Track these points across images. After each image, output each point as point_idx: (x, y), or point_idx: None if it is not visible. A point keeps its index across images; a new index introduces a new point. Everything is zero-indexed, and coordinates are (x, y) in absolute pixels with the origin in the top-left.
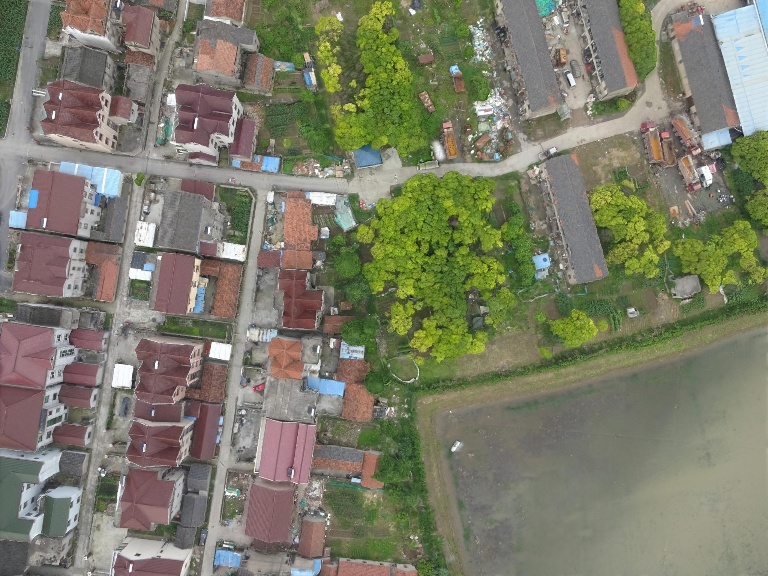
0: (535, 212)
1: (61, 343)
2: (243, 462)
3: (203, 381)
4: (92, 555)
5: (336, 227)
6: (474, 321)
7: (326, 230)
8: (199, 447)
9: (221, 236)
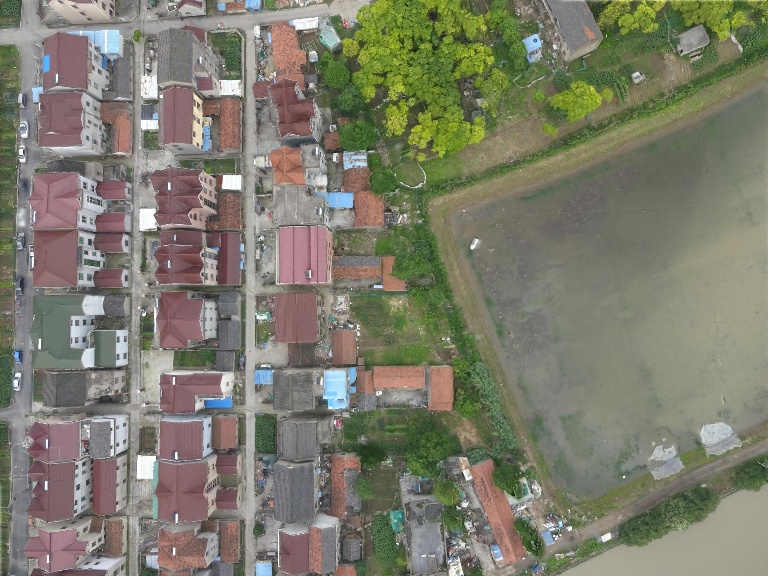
0: None
1: (88, 191)
2: (269, 286)
3: (220, 212)
4: (145, 391)
5: (323, 50)
6: (473, 116)
7: (314, 53)
8: (225, 273)
9: (218, 79)
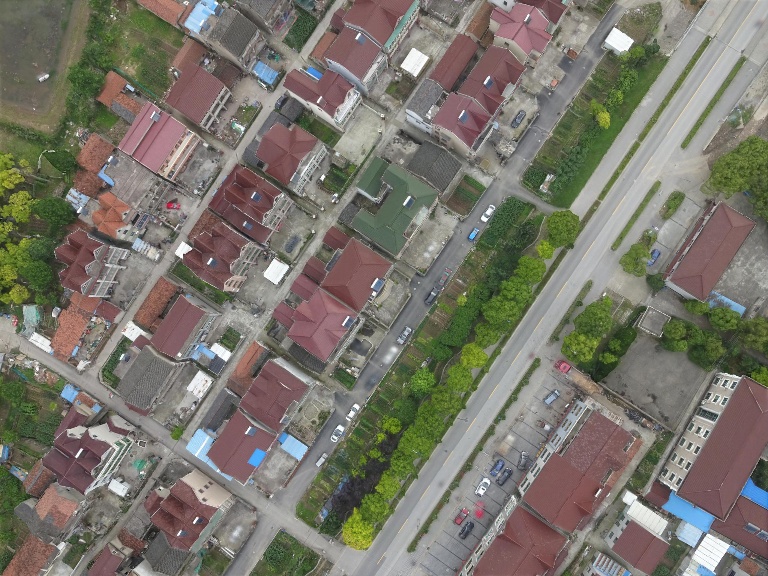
0: None
1: None
2: None
3: None
4: None
5: (46, 313)
6: None
7: (54, 314)
8: None
9: None
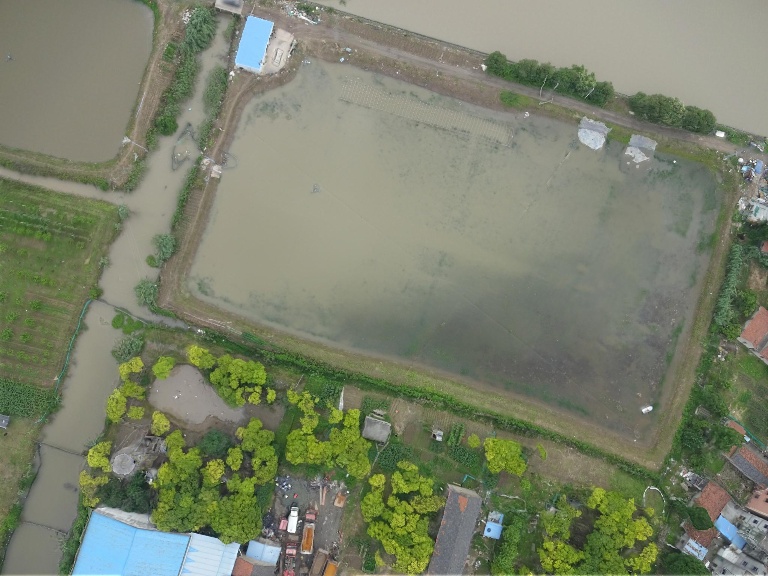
0: (467, 575)
1: None
2: None
3: None
4: None
5: None
6: None
7: None
8: None
9: None
